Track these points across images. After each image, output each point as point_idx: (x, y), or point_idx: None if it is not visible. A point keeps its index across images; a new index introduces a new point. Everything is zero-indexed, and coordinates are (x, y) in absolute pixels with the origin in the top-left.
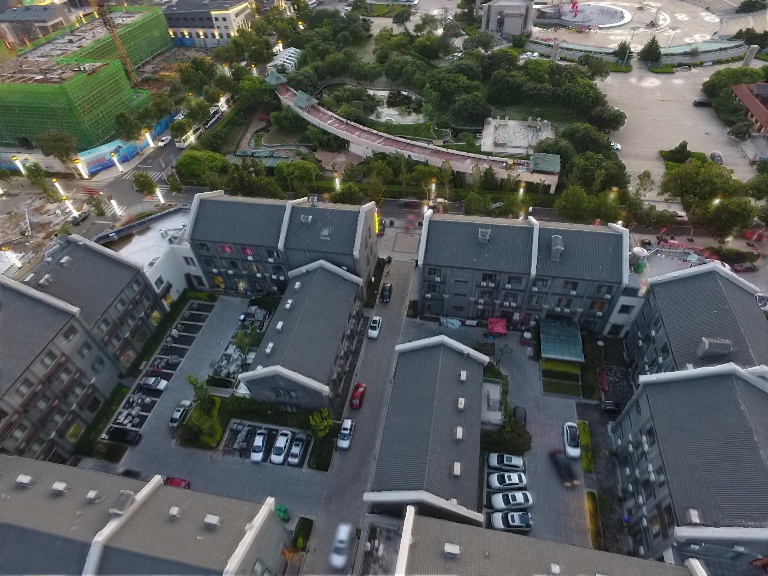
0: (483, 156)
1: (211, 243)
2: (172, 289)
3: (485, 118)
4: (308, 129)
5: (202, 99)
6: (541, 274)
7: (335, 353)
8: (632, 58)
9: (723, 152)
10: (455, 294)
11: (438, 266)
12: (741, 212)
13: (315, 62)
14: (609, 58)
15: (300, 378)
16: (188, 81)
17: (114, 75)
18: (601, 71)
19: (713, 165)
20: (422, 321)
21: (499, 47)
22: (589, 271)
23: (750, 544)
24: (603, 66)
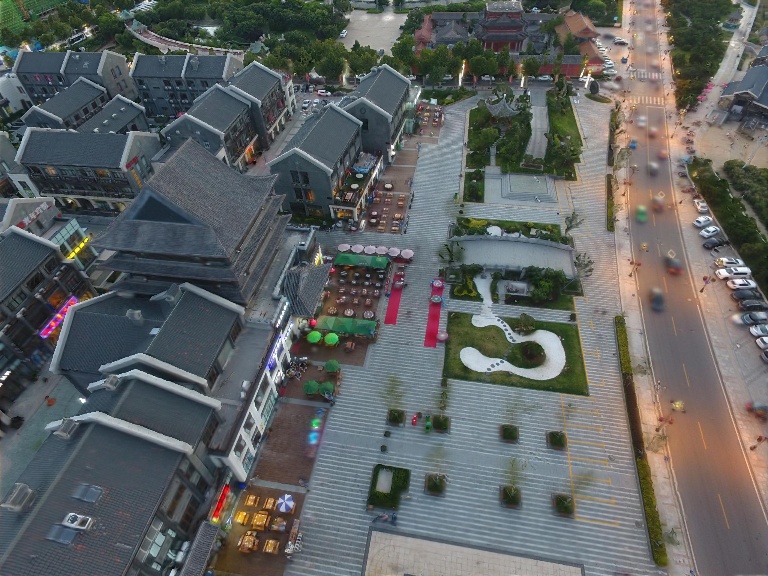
0: (230, 50)
1: (28, 74)
2: (10, 105)
3: (258, 37)
4: (134, 41)
5: (64, 23)
6: (187, 77)
7: (74, 111)
8: (388, 5)
9: (390, 50)
10: (158, 98)
11: (140, 77)
12: (329, 60)
13: (160, 7)
14: (372, 5)
15: (46, 112)
16: (63, 16)
17: (6, 8)
18: (342, 8)
19: (331, 40)
20: (148, 118)
21: (307, 1)
22: (209, 74)
23: (180, 128)
24: (343, 4)
